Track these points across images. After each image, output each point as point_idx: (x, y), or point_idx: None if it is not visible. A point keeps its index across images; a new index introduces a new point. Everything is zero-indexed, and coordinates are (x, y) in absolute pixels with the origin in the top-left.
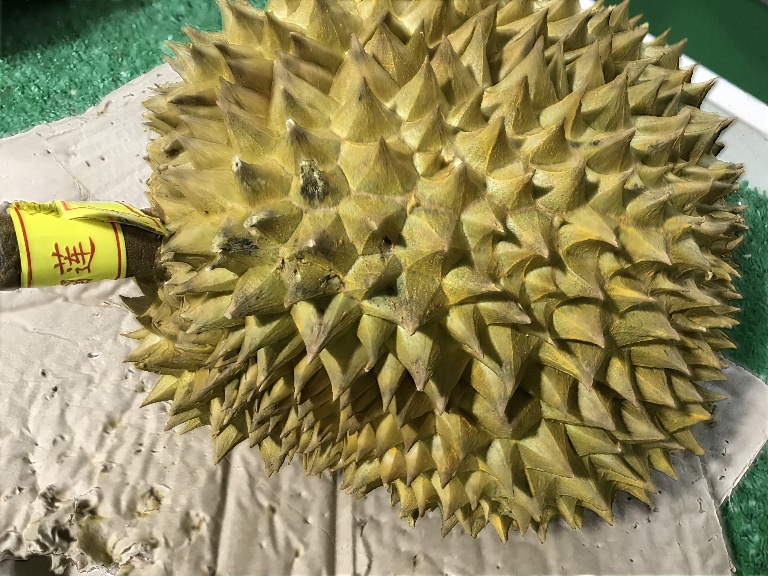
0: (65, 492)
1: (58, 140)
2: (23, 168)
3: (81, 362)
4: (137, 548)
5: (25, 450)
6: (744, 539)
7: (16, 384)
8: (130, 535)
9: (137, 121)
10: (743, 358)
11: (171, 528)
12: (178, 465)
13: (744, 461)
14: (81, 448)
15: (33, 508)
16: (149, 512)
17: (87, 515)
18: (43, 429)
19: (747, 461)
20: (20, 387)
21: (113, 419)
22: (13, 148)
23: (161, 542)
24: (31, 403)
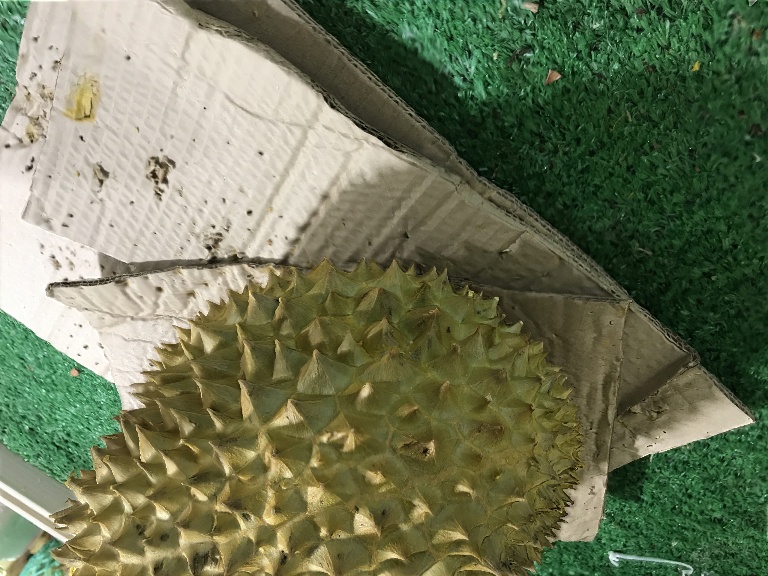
0: None
1: (30, 216)
2: (27, 191)
3: None
4: None
5: None
6: (656, 472)
7: None
8: None
9: (65, 164)
10: (747, 354)
11: None
12: None
13: (675, 445)
14: None
15: None
16: None
17: None
18: None
19: (678, 445)
20: None
21: None
22: (4, 167)
23: None
24: None
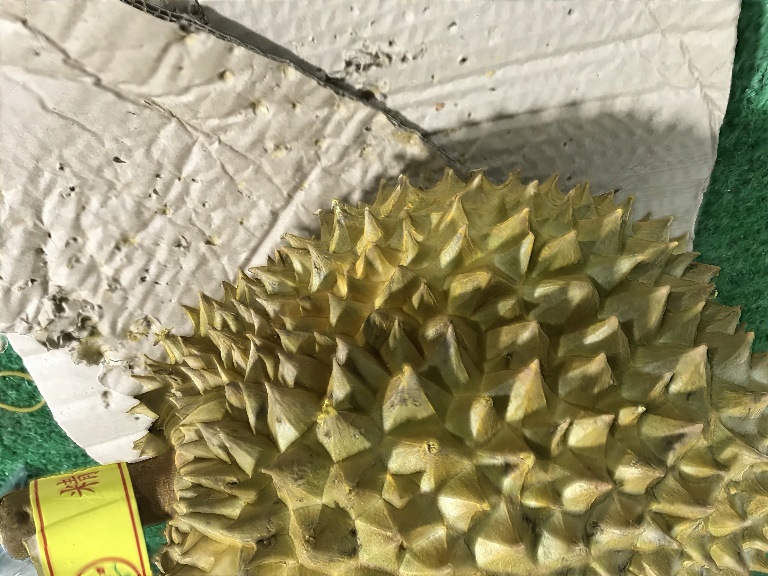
0: (72, 293)
1: None
2: None
3: (105, 165)
4: (123, 364)
5: (38, 242)
6: None
7: (30, 172)
8: (119, 352)
9: None
10: None
11: (152, 357)
12: (174, 305)
13: None
14: (91, 256)
15: (43, 304)
16: (139, 336)
17: (88, 332)
18: (57, 227)
19: None
20: (35, 175)
21: (127, 236)
22: None
23: (142, 364)
24: (46, 196)
